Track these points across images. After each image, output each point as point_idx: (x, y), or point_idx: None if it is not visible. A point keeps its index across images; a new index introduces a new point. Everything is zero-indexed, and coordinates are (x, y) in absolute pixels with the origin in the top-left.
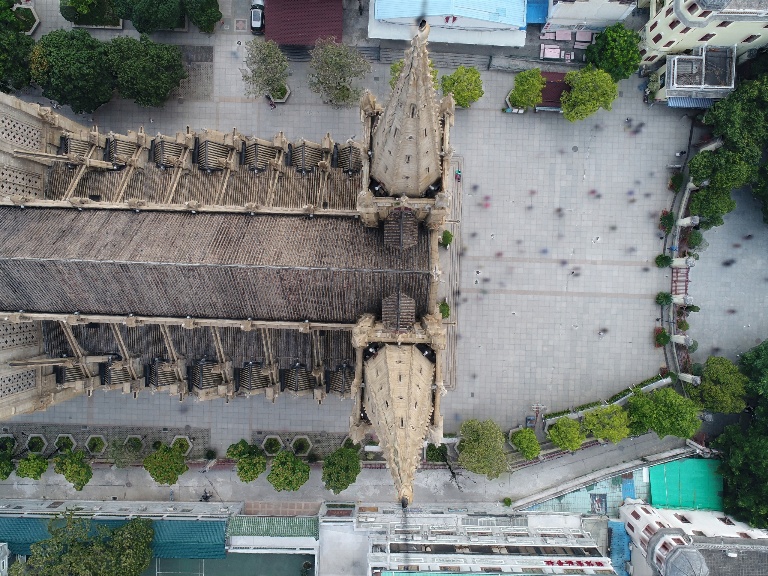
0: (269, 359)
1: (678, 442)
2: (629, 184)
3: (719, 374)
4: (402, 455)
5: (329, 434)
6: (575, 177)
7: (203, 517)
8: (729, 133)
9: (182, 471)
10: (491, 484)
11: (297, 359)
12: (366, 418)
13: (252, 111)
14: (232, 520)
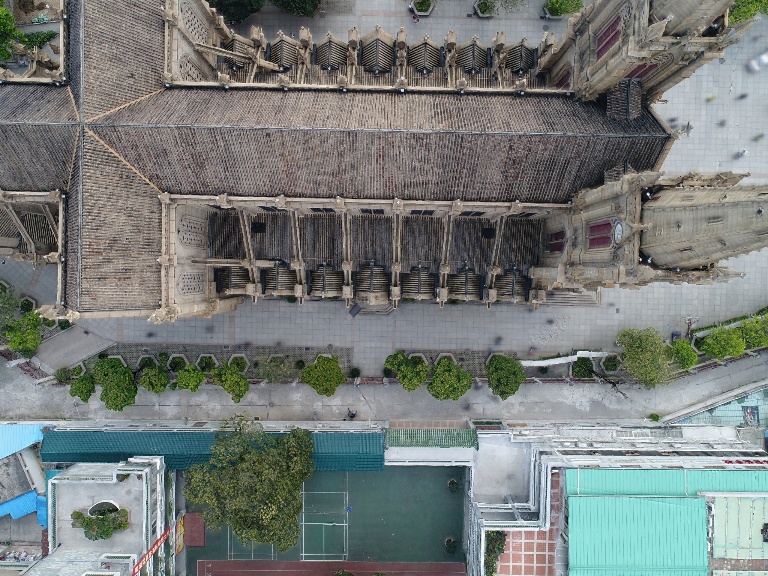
0: (445, 259)
1: None
2: None
3: None
4: None
5: (473, 352)
6: (722, 89)
7: (356, 432)
8: None
9: (342, 381)
10: (637, 400)
11: (465, 263)
12: (645, 262)
13: (395, 25)
14: (389, 432)
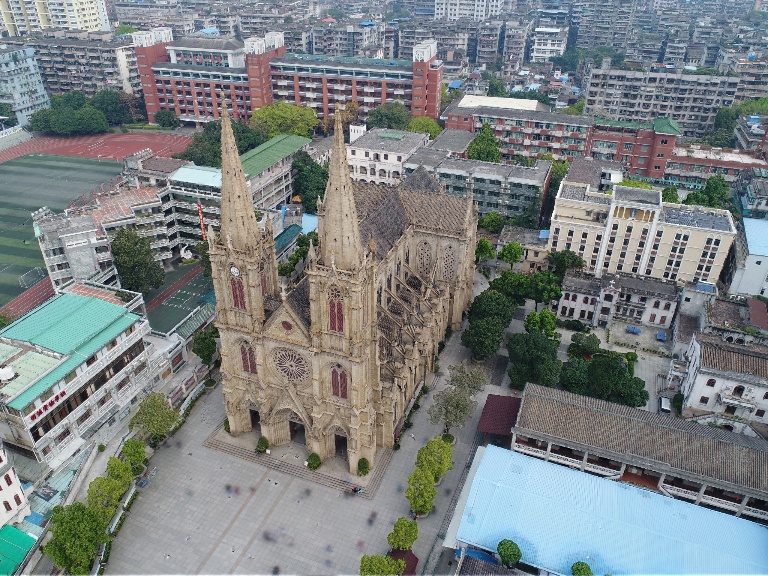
0: None
1: None
2: None
3: None
4: None
5: None
6: None
7: None
8: None
9: None
10: None
11: None
12: None
13: None
14: None
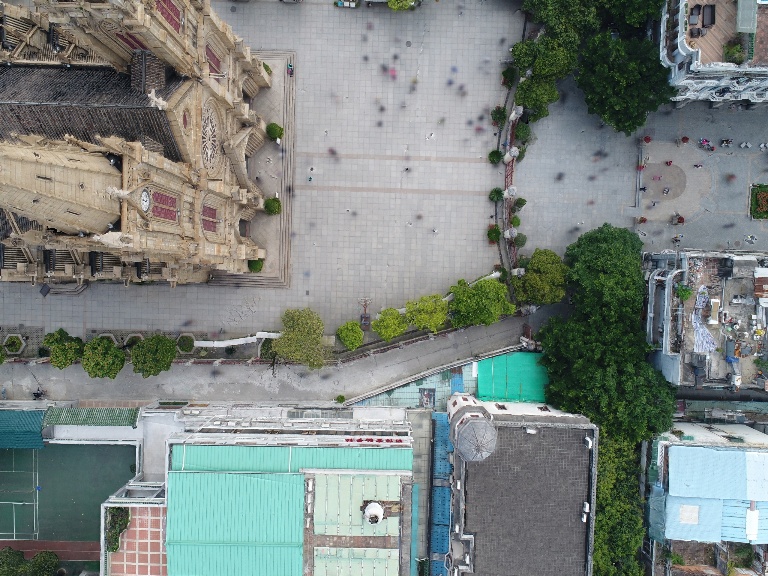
0: None
1: (512, 340)
2: (463, 80)
3: (540, 263)
4: None
5: (164, 333)
6: (409, 72)
7: (27, 410)
8: (543, 16)
9: None
10: (326, 382)
11: None
12: (52, 228)
13: None
14: (52, 410)
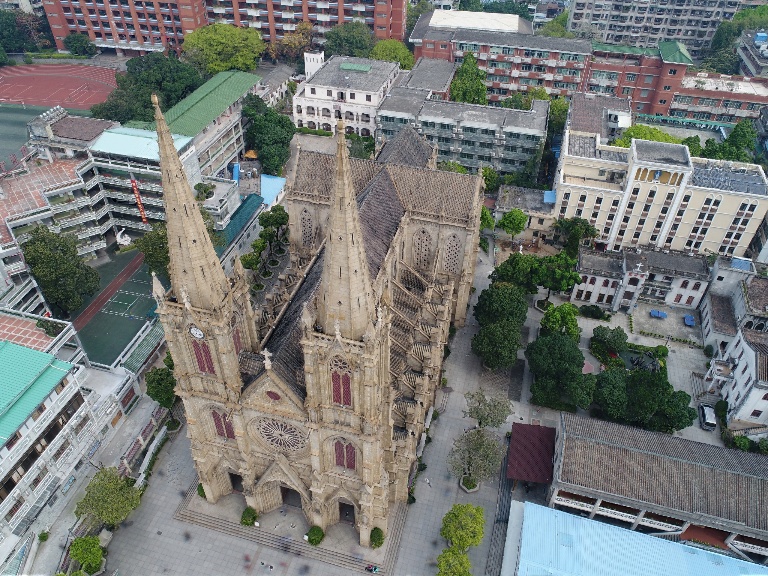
0: None
1: None
2: None
3: None
4: (169, 137)
5: None
6: None
7: None
8: None
9: None
10: None
11: None
12: None
13: None
14: None
